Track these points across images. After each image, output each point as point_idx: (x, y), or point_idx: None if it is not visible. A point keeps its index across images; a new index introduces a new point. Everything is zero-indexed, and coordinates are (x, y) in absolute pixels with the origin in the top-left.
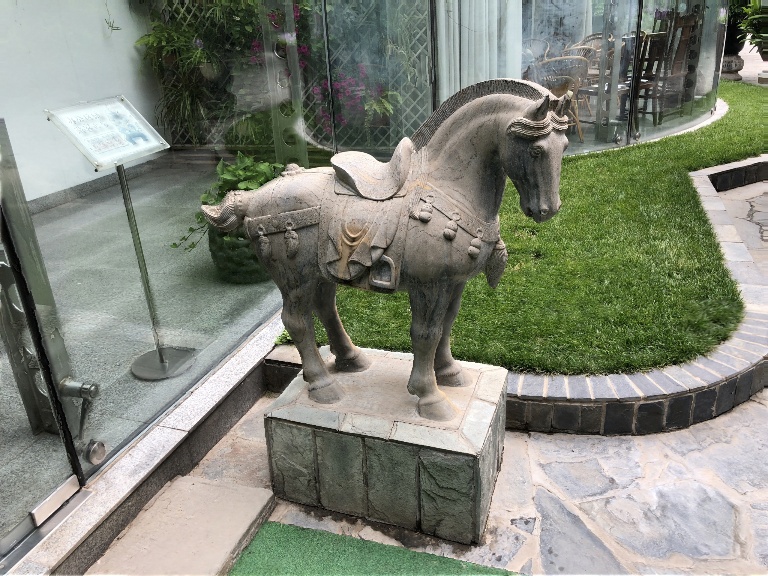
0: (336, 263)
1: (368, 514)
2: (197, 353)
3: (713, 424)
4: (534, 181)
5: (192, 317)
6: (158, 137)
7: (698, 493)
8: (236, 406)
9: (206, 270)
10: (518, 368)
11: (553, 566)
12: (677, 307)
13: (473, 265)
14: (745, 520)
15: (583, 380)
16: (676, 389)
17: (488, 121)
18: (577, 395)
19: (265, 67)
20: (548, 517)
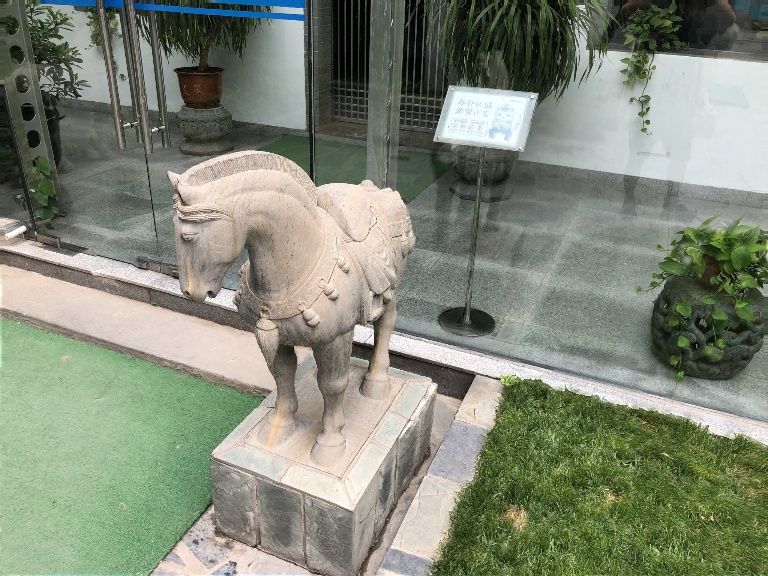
0: None
1: None
2: (487, 337)
3: None
4: None
5: (562, 328)
6: (524, 142)
7: None
8: None
9: None
10: (430, 575)
11: None
12: None
13: None
14: None
15: None
16: None
17: None
18: None
19: None
20: None
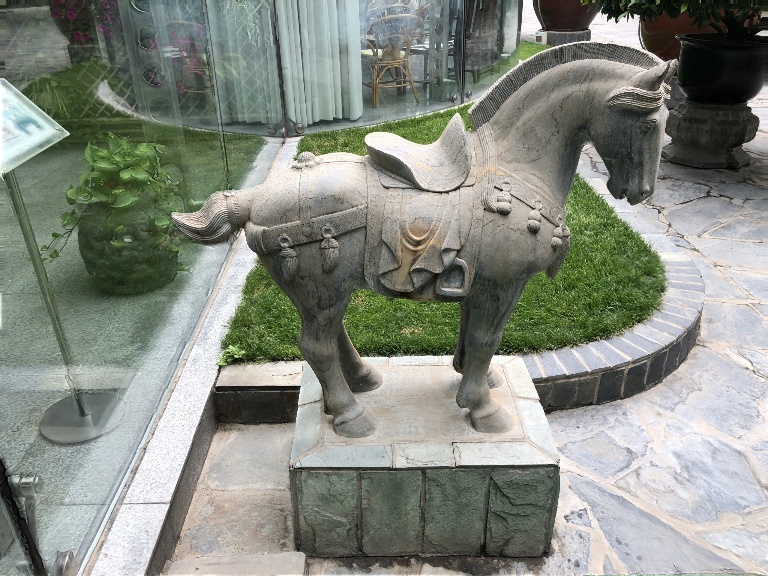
0: (393, 273)
1: (422, 550)
2: (122, 394)
3: (680, 374)
4: (639, 159)
5: (87, 347)
6: (50, 121)
7: (705, 446)
8: (198, 452)
9: (74, 282)
10: (505, 351)
11: (631, 557)
12: (609, 264)
13: (553, 258)
14: (756, 464)
15: (570, 353)
16: (655, 348)
17: (577, 91)
18: (574, 370)
19: (120, 23)
20: (596, 504)
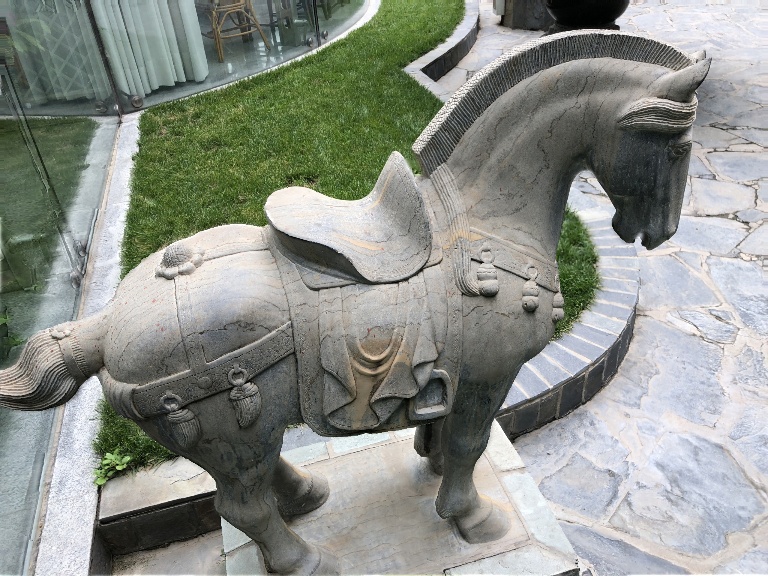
0: (345, 409)
1: None
2: None
3: (632, 357)
4: (664, 194)
5: None
6: None
7: (686, 447)
8: None
9: None
10: None
11: None
12: None
13: None
14: (742, 458)
15: (523, 367)
16: (610, 340)
17: (572, 108)
18: (534, 390)
19: None
20: (598, 560)
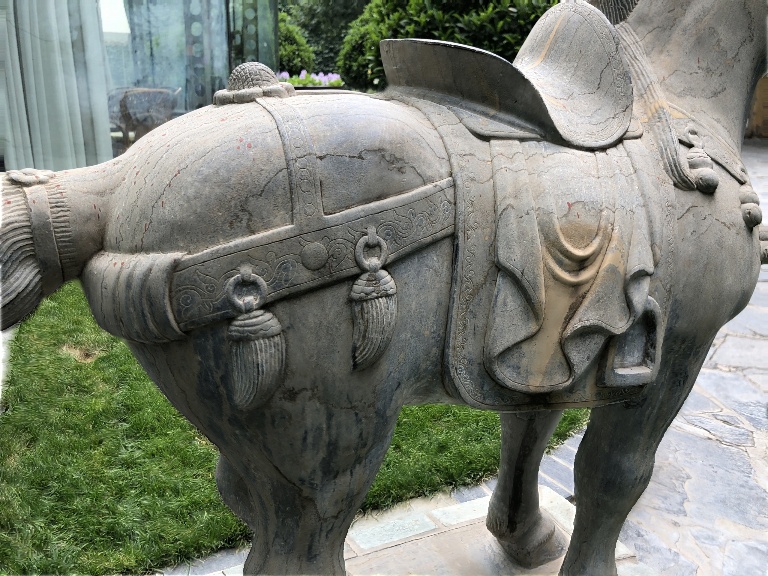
0: (522, 348)
1: None
2: None
3: None
4: None
5: None
6: None
7: (759, 556)
8: None
9: None
10: (473, 477)
11: None
12: None
13: None
14: None
15: (553, 461)
16: None
17: None
18: None
19: None
20: None
